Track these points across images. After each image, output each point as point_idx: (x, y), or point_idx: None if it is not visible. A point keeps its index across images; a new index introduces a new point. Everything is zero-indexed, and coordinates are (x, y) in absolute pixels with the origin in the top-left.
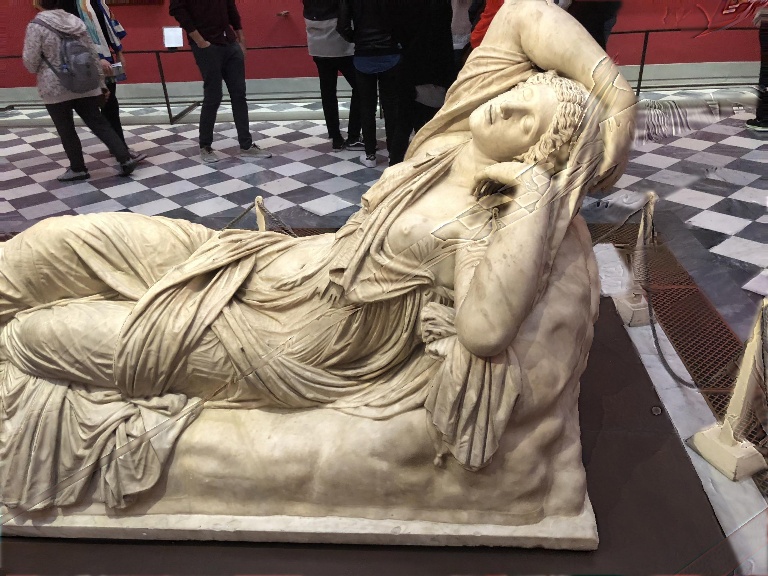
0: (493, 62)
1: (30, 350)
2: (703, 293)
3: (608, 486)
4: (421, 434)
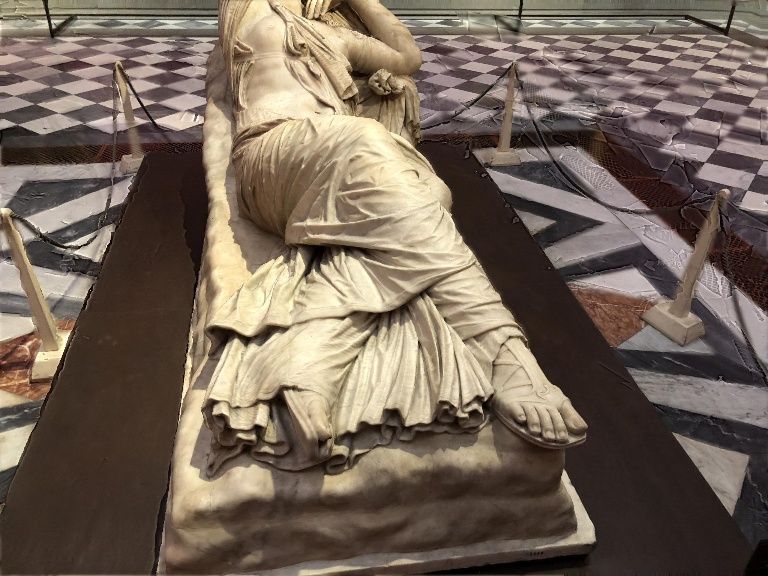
0: None
1: (449, 211)
2: (117, 143)
3: None
4: (411, 140)
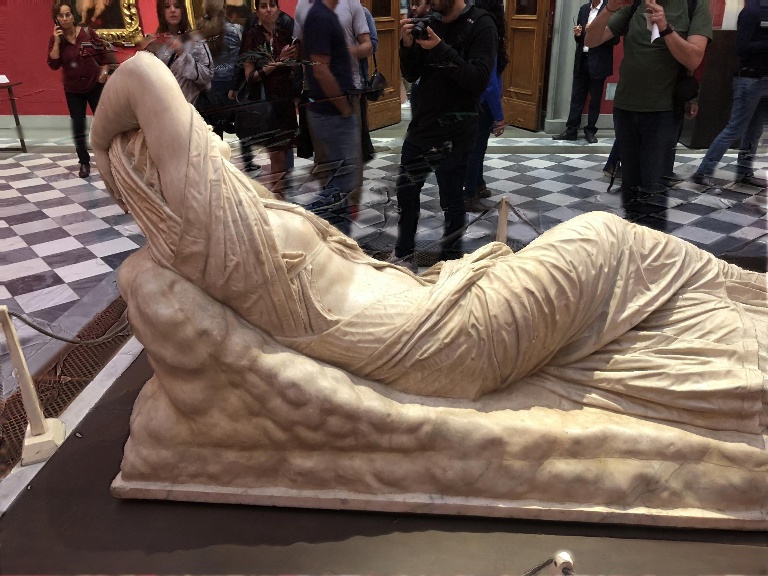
0: None
1: None
2: None
3: None
4: None
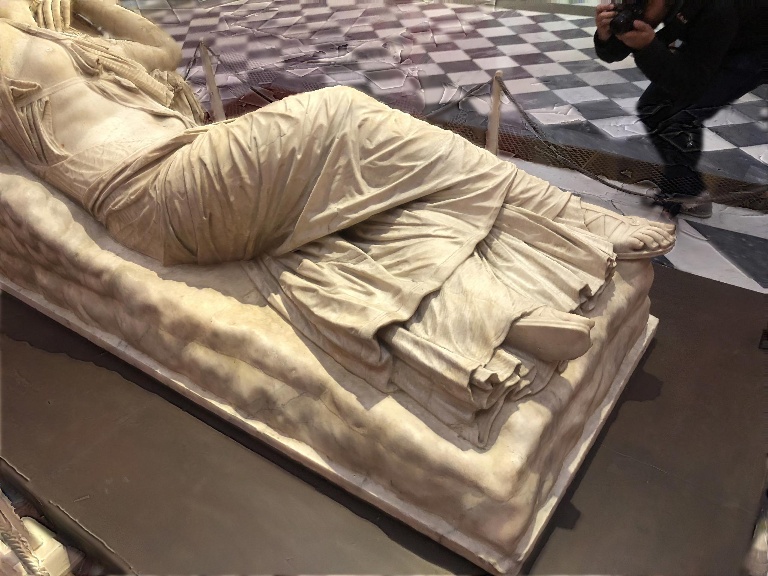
0: None
1: None
2: None
3: None
4: None
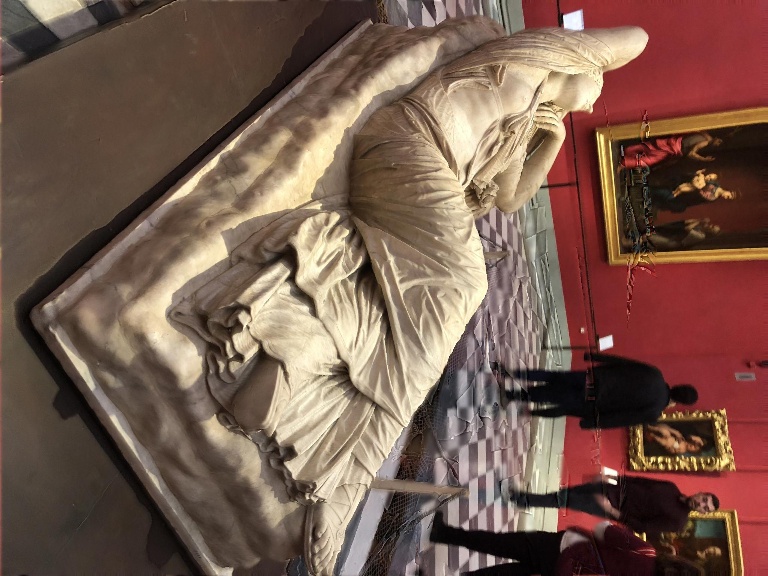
0: (605, 65)
1: None
2: None
3: None
4: None
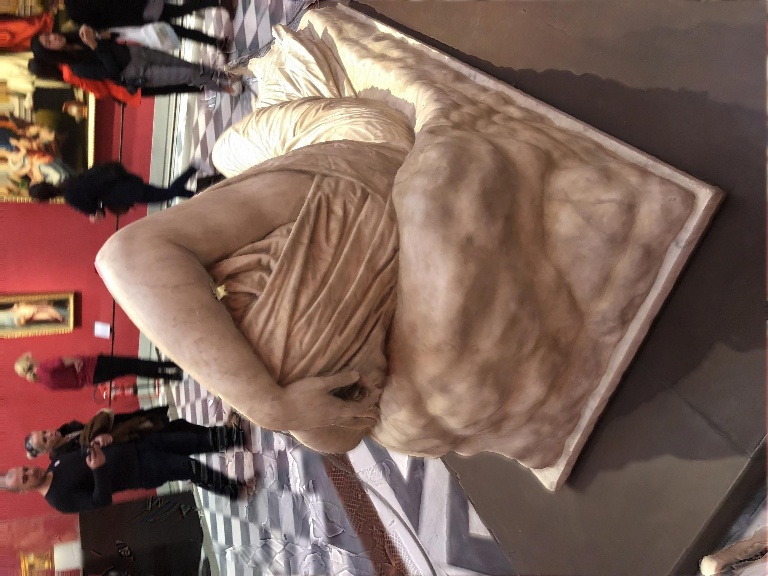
0: None
1: None
2: None
3: (622, 448)
4: None
